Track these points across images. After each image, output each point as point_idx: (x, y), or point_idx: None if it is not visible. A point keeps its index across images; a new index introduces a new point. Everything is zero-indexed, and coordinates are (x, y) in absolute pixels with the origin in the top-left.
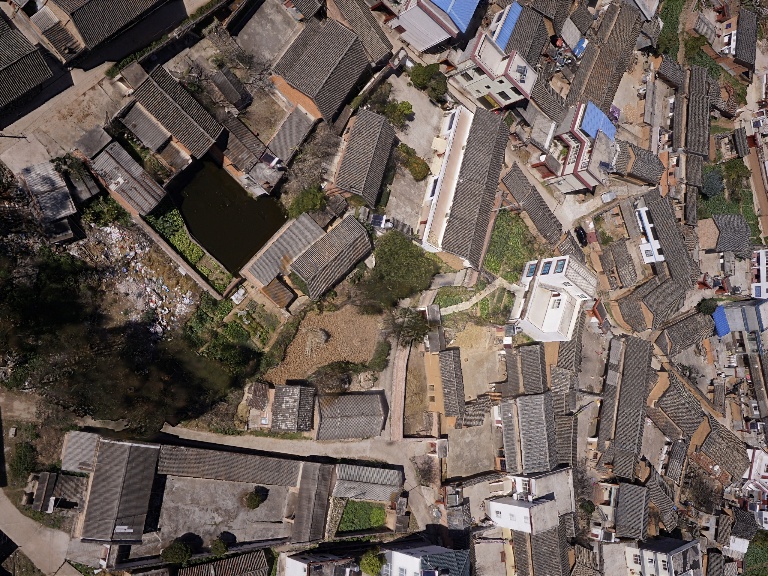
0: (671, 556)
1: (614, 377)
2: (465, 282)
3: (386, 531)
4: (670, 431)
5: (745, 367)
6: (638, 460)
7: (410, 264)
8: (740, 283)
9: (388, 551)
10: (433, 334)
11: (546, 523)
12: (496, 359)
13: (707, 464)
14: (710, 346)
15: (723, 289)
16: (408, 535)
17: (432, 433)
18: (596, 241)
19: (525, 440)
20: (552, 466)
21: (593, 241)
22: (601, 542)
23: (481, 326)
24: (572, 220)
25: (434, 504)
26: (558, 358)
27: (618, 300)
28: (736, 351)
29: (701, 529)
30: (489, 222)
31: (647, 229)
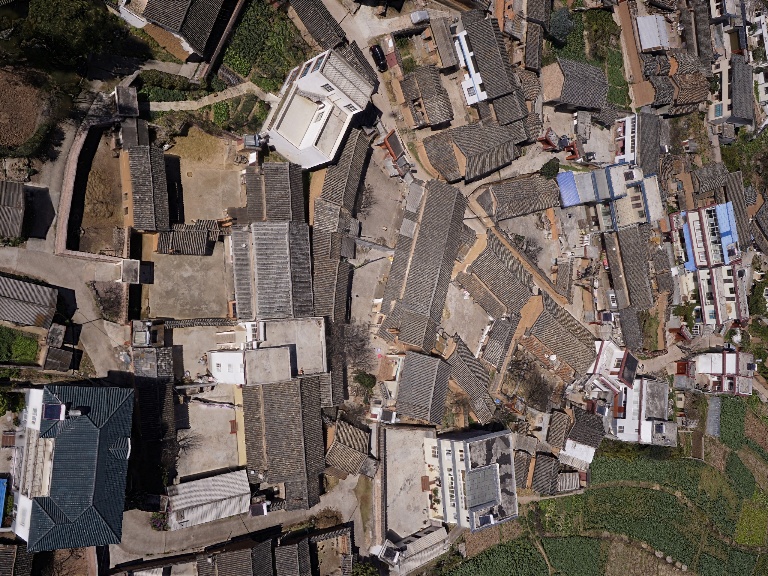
0: (468, 443)
1: (410, 227)
2: (194, 78)
3: (30, 366)
4: (491, 306)
5: (602, 251)
6: (446, 336)
7: (59, 4)
8: (601, 154)
9: (27, 390)
10: (128, 126)
11: (270, 374)
12: (238, 181)
13: (542, 353)
14: (554, 218)
15: (574, 153)
16: (76, 380)
17: (123, 254)
18: (396, 64)
19: (260, 277)
20: (299, 314)
21: (394, 64)
22: (380, 423)
23: (214, 135)
24: (368, 37)
25: (123, 346)
26: (322, 187)
27: (423, 138)
28: (591, 230)
29: (533, 430)
30: (234, 9)
31: (467, 60)
